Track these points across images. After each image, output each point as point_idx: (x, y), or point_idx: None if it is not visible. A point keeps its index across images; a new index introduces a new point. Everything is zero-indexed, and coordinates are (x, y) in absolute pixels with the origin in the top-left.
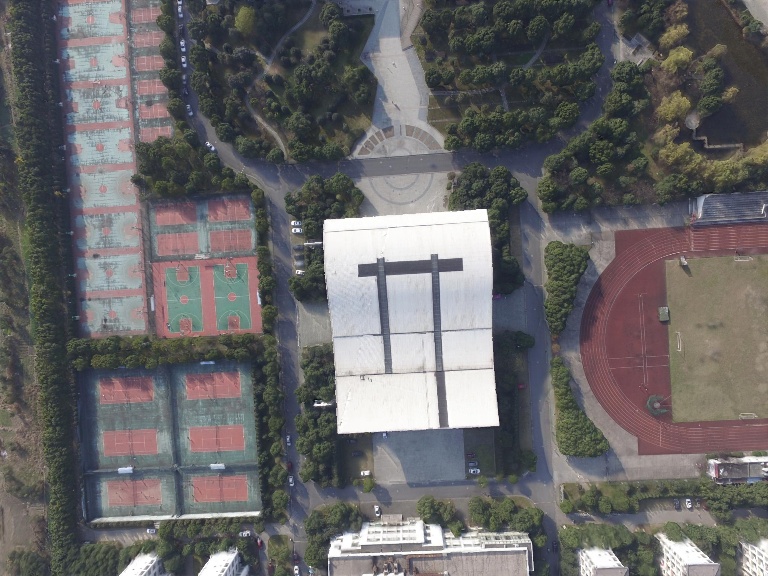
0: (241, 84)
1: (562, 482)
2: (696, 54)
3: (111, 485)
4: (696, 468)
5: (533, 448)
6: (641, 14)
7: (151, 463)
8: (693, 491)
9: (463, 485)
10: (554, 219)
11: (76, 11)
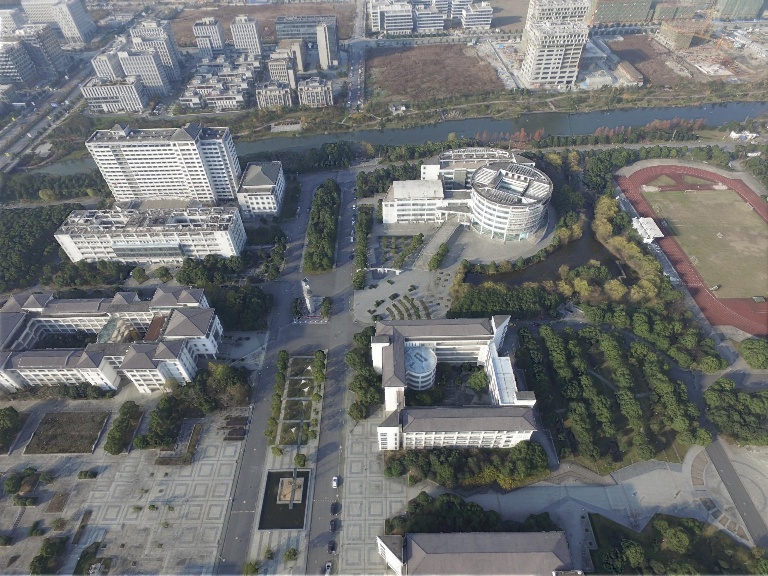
0: None
1: None
2: None
3: None
4: None
5: None
6: (551, 305)
7: None
8: None
9: None
10: None
11: None
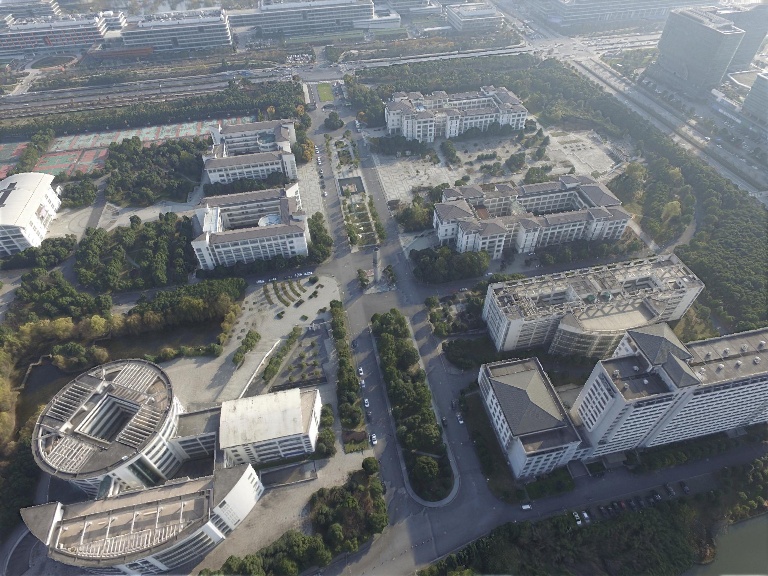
0: None
1: None
2: (111, 351)
3: None
4: None
5: None
6: None
7: None
8: None
9: None
10: None
11: None
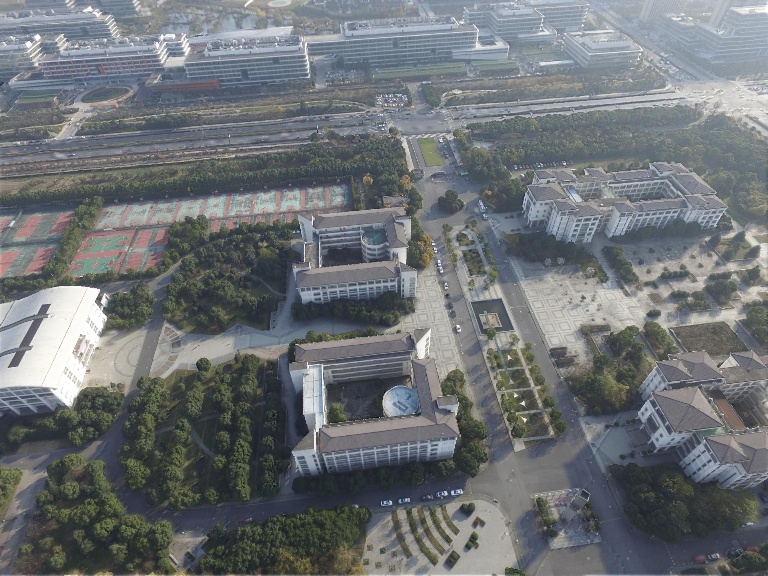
0: None
1: None
2: None
3: (8, 220)
4: None
5: None
6: None
7: (10, 235)
8: None
9: None
10: None
11: (296, 194)
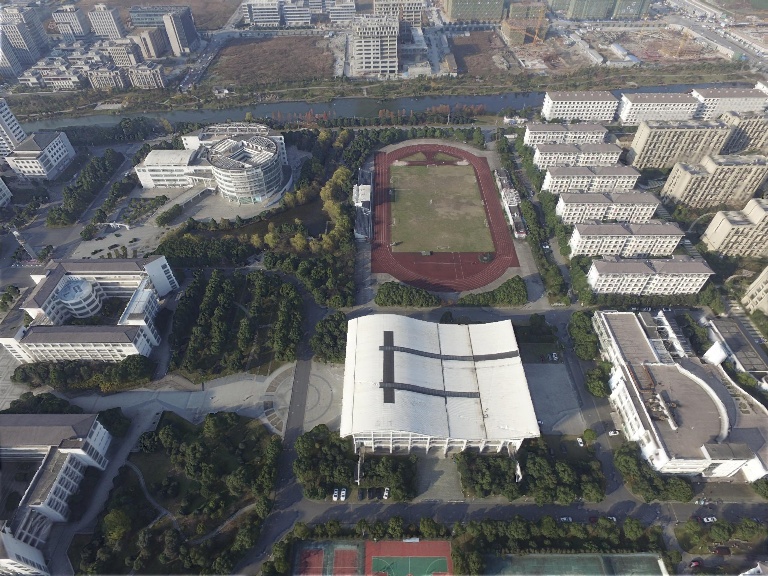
0: (177, 540)
1: (549, 305)
2: None
3: None
4: (523, 243)
5: (528, 321)
6: (237, 254)
7: None
8: (537, 243)
9: (569, 366)
10: (359, 303)
11: None
